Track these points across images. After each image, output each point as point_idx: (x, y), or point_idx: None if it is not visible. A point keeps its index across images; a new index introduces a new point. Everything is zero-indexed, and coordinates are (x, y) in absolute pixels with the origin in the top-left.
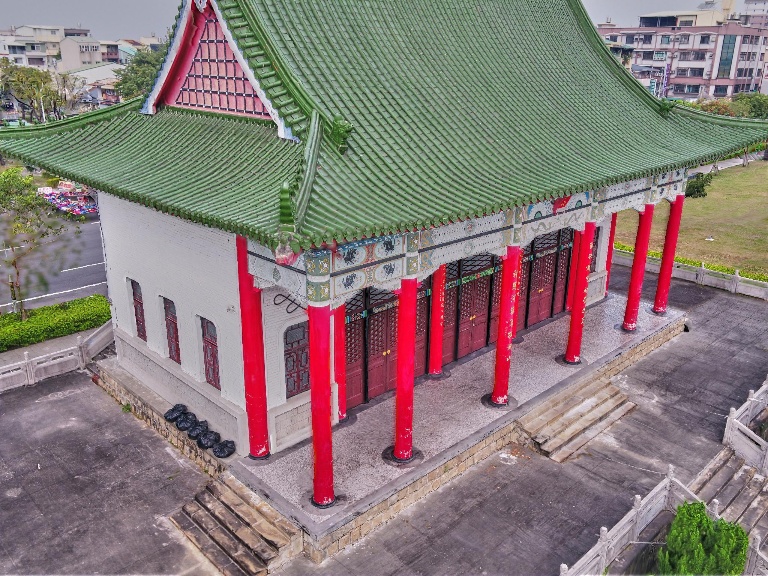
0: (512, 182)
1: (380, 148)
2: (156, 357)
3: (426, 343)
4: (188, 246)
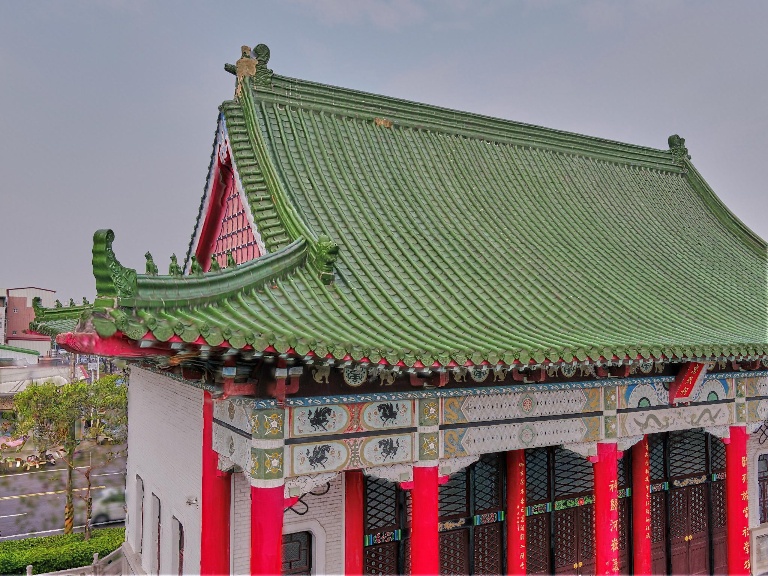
0: (579, 335)
1: (389, 286)
2: None
3: None
4: (174, 423)
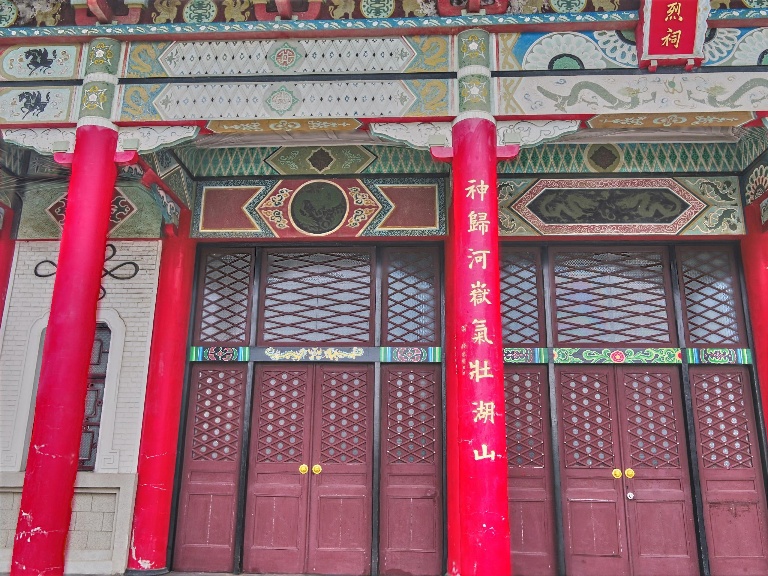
0: None
1: None
2: None
3: (441, 487)
4: None
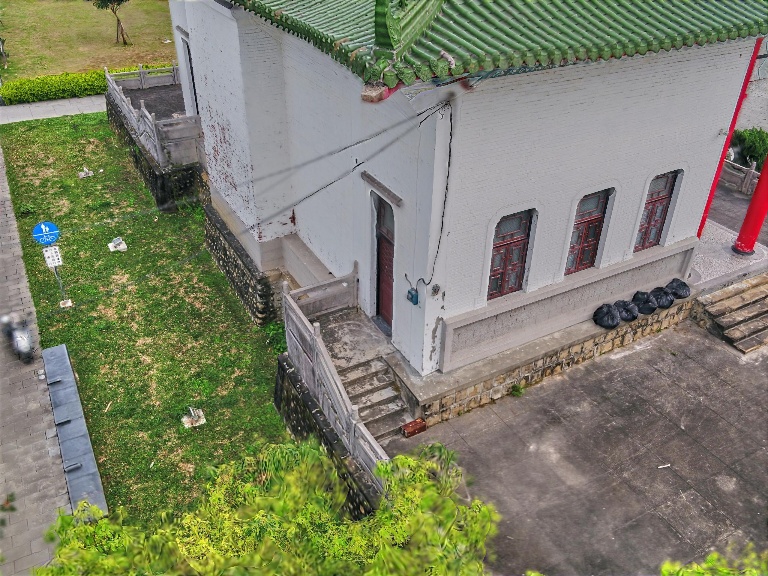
0: None
1: None
2: (558, 287)
3: None
4: (670, 94)
